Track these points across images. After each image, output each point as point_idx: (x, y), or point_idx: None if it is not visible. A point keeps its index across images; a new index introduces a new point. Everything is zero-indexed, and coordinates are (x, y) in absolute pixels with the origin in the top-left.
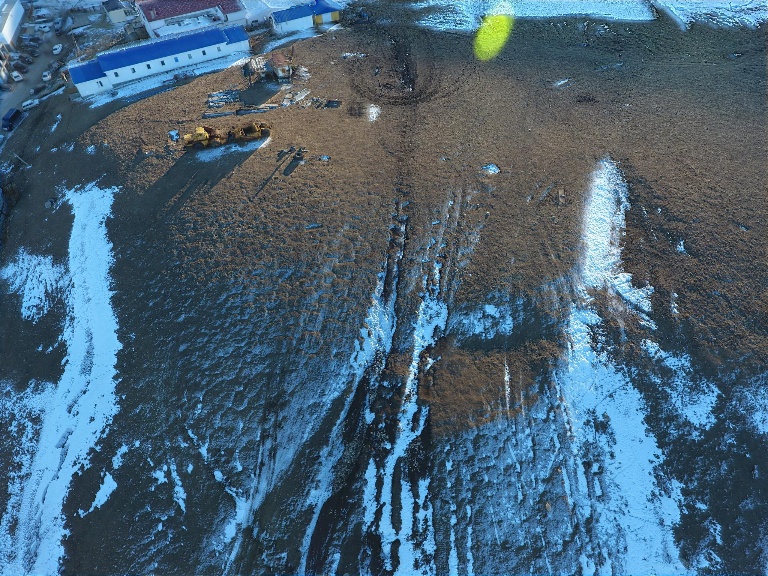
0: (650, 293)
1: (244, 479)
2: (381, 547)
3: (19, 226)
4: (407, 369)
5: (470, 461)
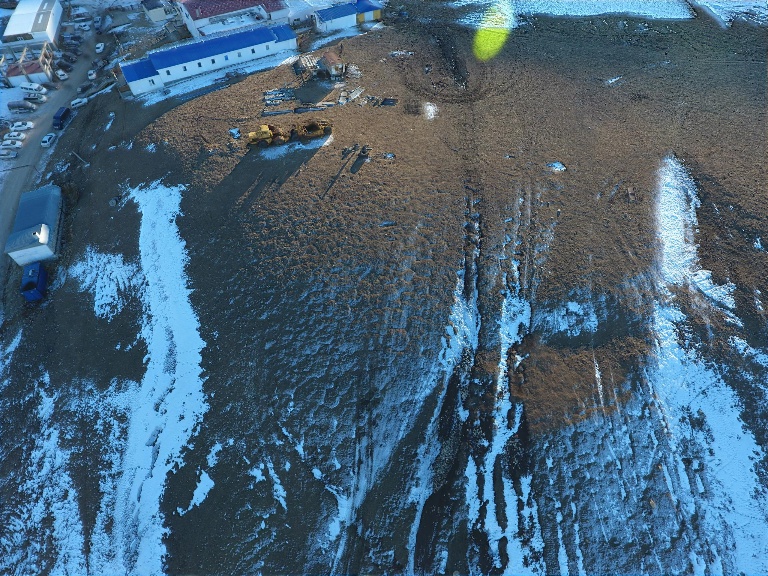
0: (732, 290)
1: (343, 477)
2: (489, 544)
3: (84, 224)
4: (496, 366)
5: (570, 458)
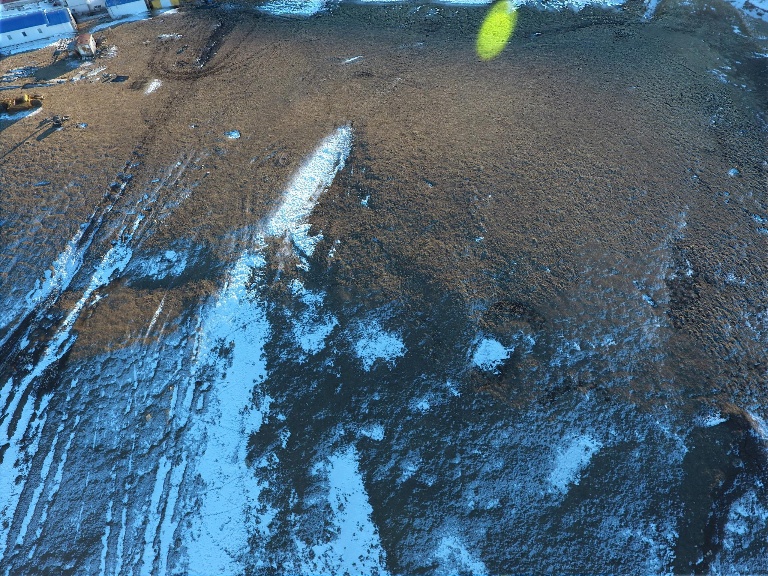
0: (318, 240)
1: None
2: None
3: None
4: (73, 304)
5: (93, 379)
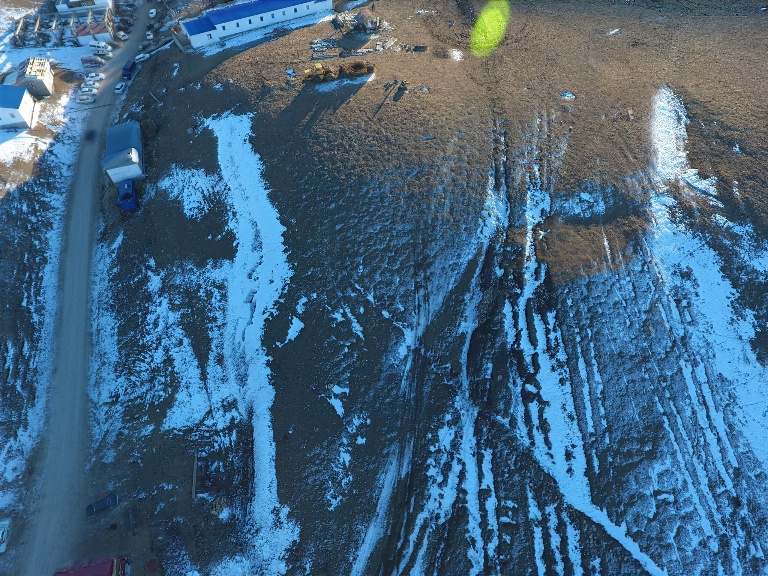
0: (715, 182)
1: (407, 316)
2: (524, 358)
3: (166, 149)
4: (524, 238)
5: (586, 299)
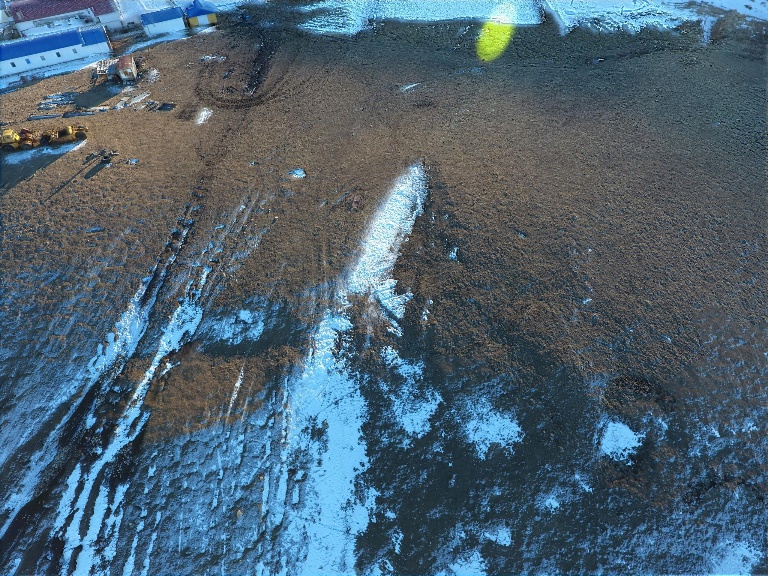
0: (407, 300)
1: None
2: (62, 553)
3: None
4: (142, 374)
5: (173, 467)
